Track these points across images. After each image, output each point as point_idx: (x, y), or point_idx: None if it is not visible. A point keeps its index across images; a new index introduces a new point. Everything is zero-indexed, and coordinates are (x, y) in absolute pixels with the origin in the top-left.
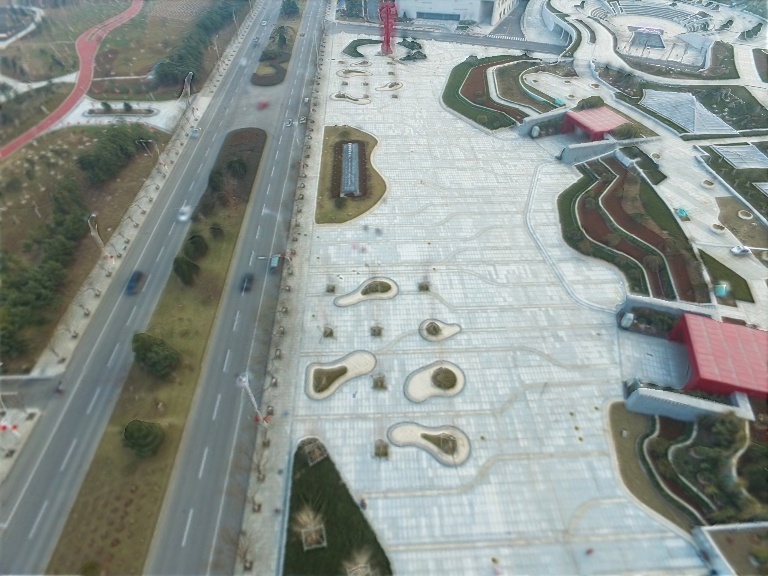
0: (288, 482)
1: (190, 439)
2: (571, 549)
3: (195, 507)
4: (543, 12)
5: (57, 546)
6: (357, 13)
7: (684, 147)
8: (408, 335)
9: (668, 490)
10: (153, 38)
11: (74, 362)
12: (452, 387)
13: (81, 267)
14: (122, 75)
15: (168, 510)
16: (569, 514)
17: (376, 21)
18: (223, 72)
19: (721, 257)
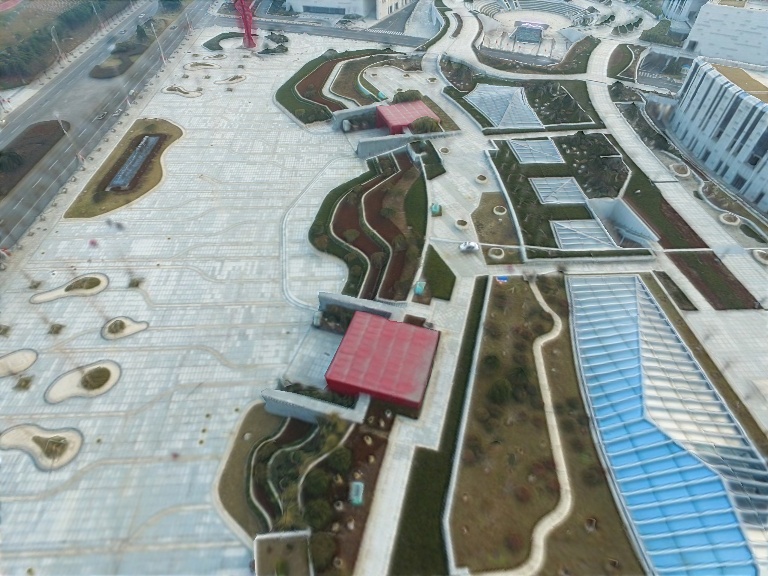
0: None
1: None
2: (120, 559)
3: None
4: None
5: None
6: None
7: (480, 141)
8: (87, 333)
9: (253, 496)
10: (10, 30)
11: None
12: (98, 387)
13: None
14: None
15: None
16: (141, 522)
17: (261, 15)
18: (66, 64)
19: (447, 253)
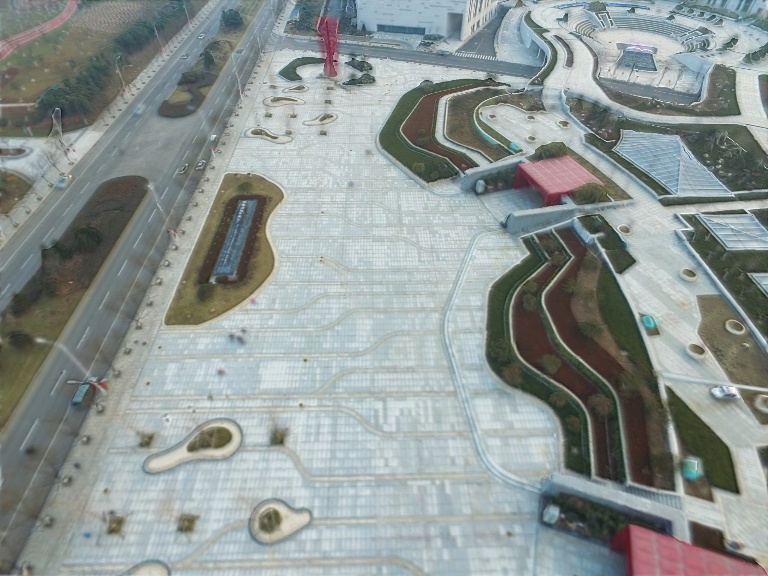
0: None
1: None
2: None
3: None
4: (521, 26)
5: None
6: (310, 25)
7: (662, 216)
8: (231, 530)
9: None
10: (63, 55)
11: None
12: None
13: None
14: (9, 102)
15: None
16: None
17: None
18: (130, 98)
19: (696, 402)
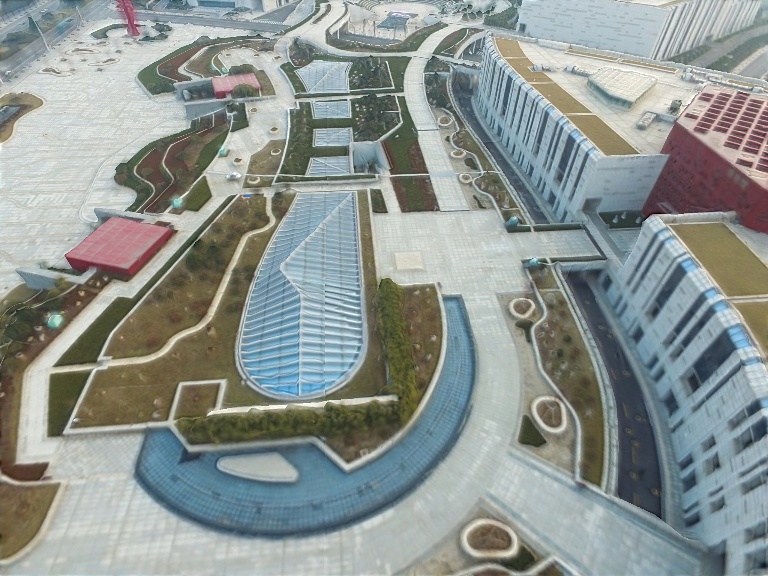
0: None
1: None
2: None
3: None
4: None
5: None
6: (141, 2)
7: (288, 103)
8: None
9: None
10: None
11: None
12: None
13: None
14: None
15: None
16: None
17: (158, 9)
18: None
19: (215, 182)
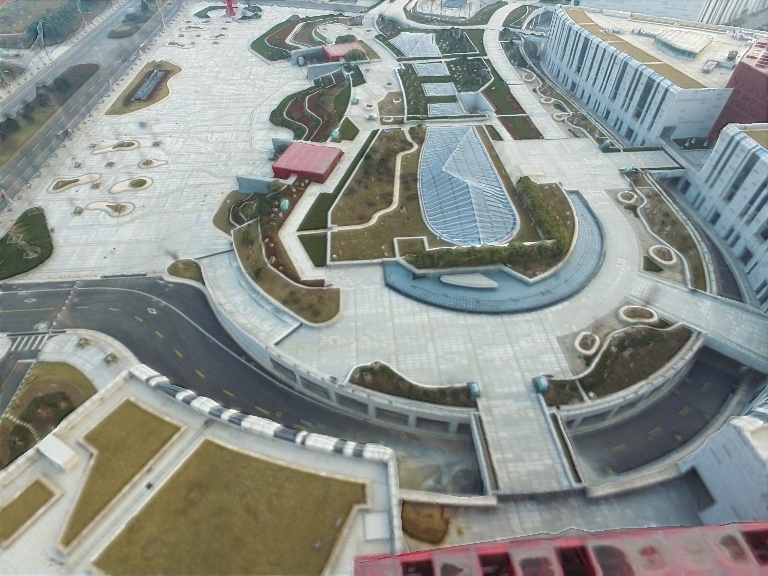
0: (13, 222)
1: None
2: (161, 244)
3: None
4: None
5: None
6: None
7: (393, 65)
8: (130, 166)
9: (231, 220)
10: (40, 7)
11: None
12: (140, 187)
13: None
14: (5, 33)
15: None
16: (171, 233)
17: None
18: (89, 30)
19: (357, 121)
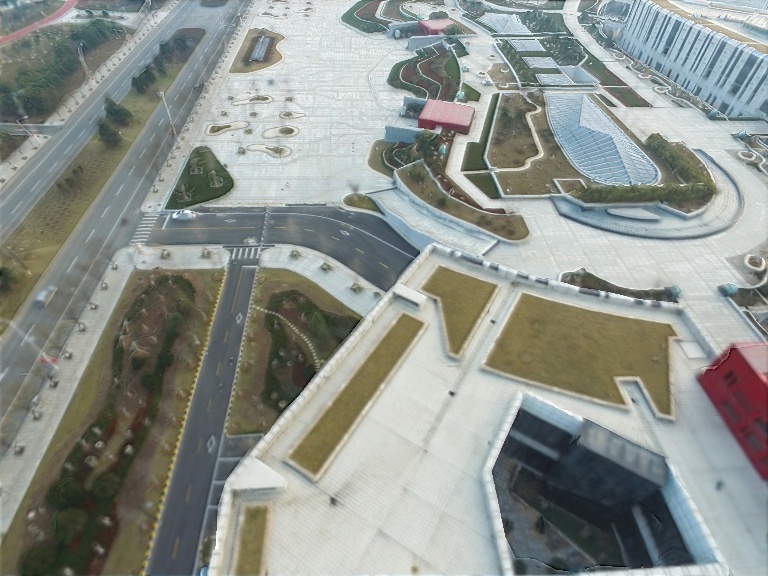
0: (187, 158)
1: (136, 146)
2: (329, 181)
3: (136, 165)
4: None
5: (64, 173)
6: None
7: (490, 40)
8: (272, 117)
9: (388, 163)
10: None
11: (70, 121)
12: (290, 134)
13: (73, 85)
14: None
15: (122, 166)
16: (334, 172)
17: None
18: None
19: (475, 86)
